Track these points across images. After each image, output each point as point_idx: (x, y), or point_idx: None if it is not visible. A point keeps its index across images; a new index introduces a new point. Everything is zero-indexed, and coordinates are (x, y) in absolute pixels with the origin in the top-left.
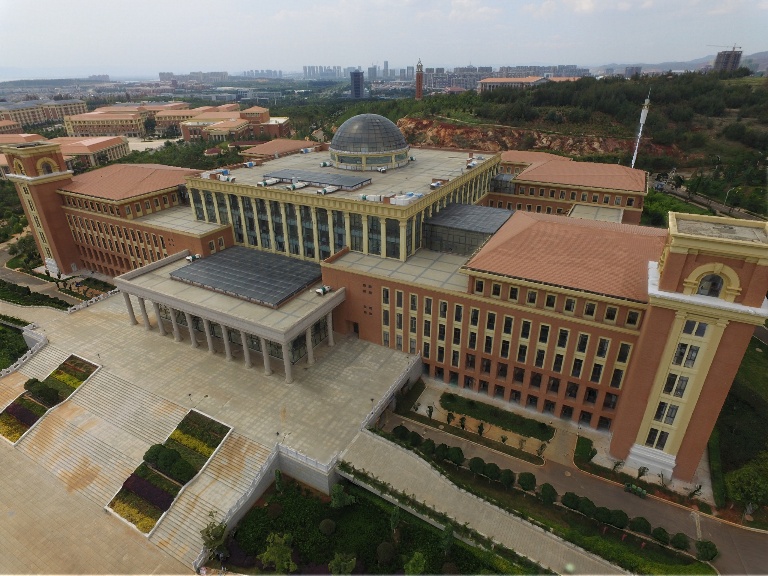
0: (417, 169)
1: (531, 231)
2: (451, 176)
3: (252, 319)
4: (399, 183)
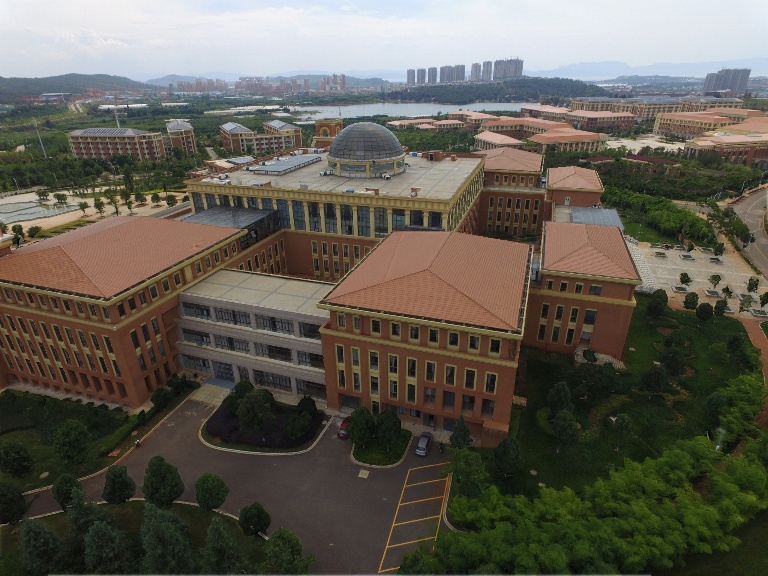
0: (340, 182)
1: (132, 217)
2: None
3: None
4: (281, 181)
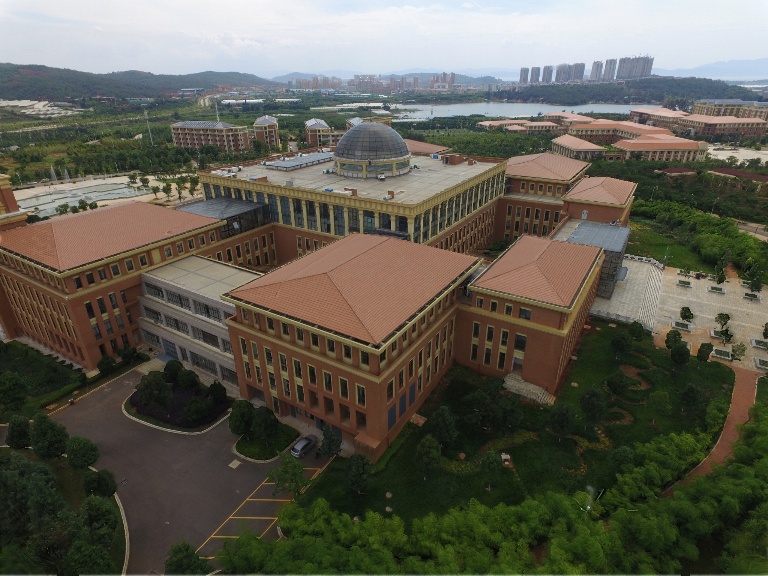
0: (335, 180)
1: (133, 202)
2: (295, 187)
3: (193, 199)
4: (283, 176)
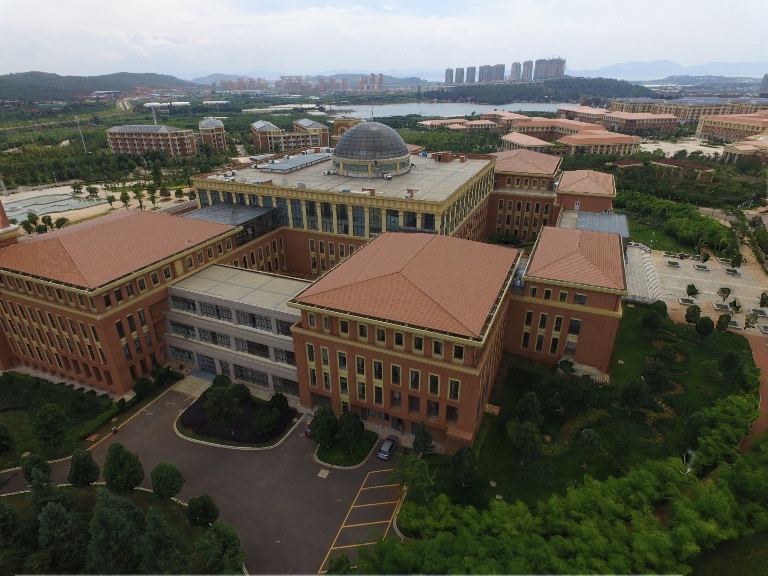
0: (341, 181)
1: None
2: None
3: None
4: (284, 179)
